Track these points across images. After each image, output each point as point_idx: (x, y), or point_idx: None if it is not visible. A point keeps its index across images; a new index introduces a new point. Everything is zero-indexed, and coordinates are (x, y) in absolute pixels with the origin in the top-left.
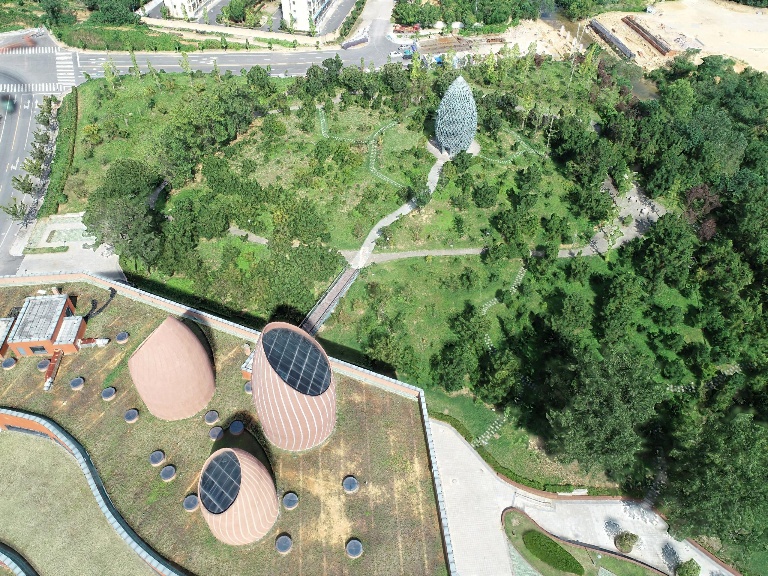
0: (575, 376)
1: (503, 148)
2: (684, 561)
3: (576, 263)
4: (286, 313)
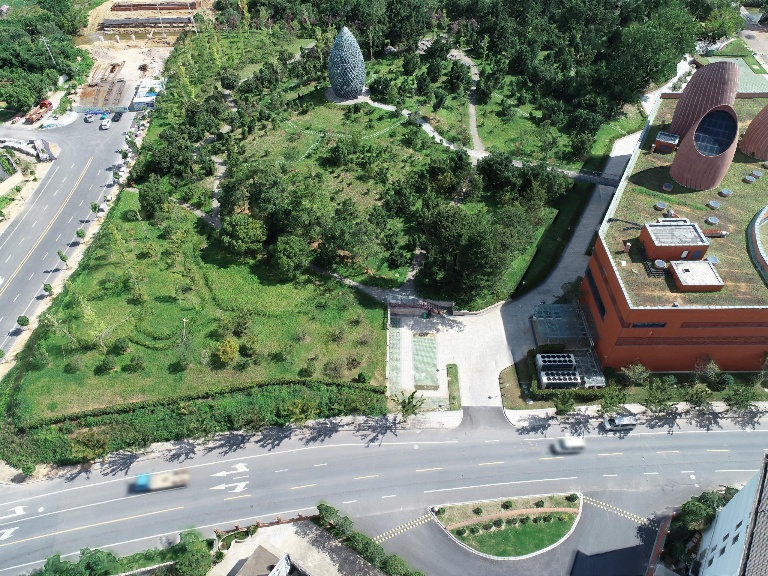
0: None
1: None
2: None
3: None
4: (560, 180)
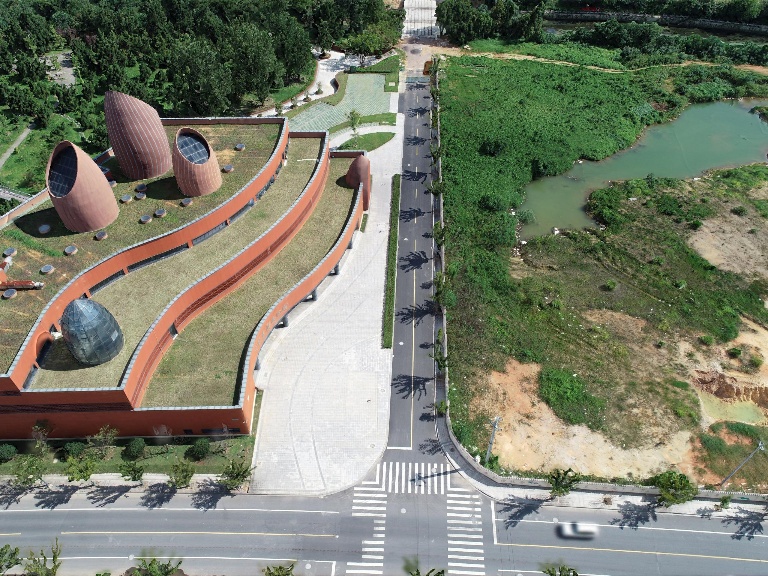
0: None
1: None
2: (274, 114)
3: (76, 94)
4: None
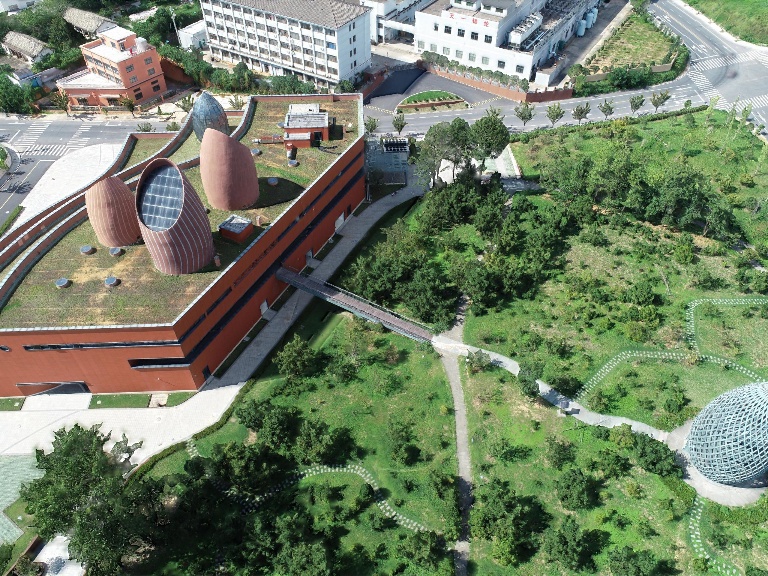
0: (239, 570)
1: (750, 552)
2: None
3: None
4: None
